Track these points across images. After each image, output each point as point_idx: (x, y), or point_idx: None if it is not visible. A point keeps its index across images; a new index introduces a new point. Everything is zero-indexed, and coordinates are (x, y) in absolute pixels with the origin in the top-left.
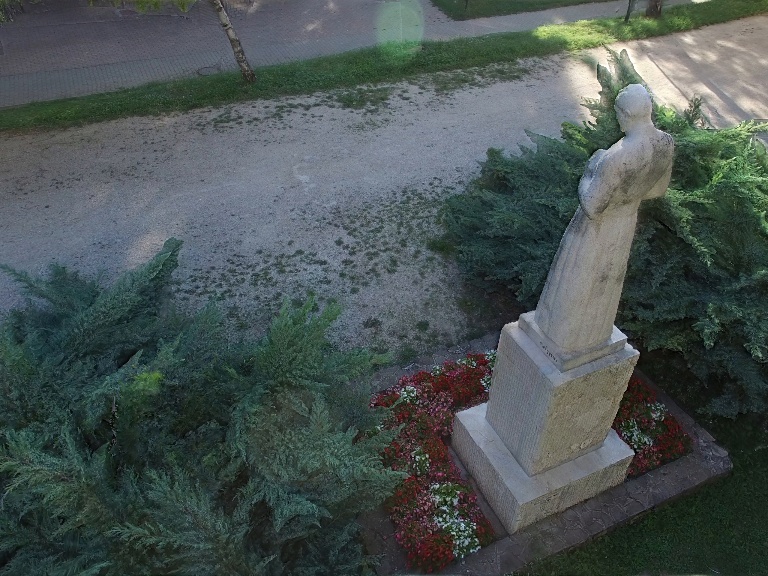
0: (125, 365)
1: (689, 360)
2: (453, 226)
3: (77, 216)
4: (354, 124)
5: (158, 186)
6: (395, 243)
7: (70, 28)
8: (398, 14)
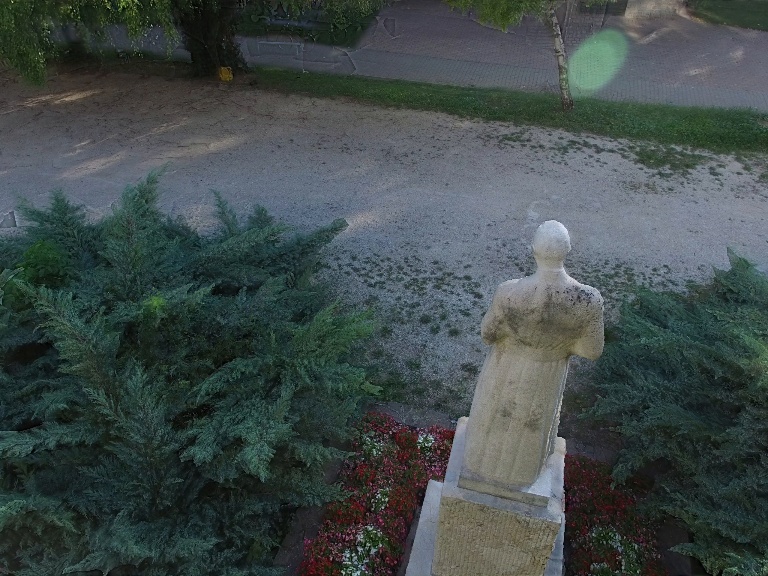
0: (178, 289)
1: None
2: (622, 319)
3: (336, 178)
4: (632, 181)
5: (410, 176)
6: None
7: (473, 24)
8: None
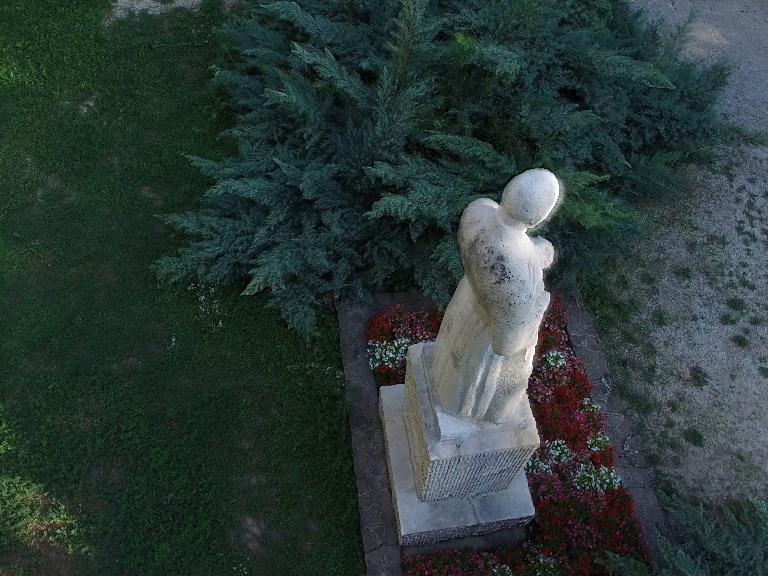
0: None
1: None
2: None
3: None
4: None
5: None
6: None
7: None
8: None
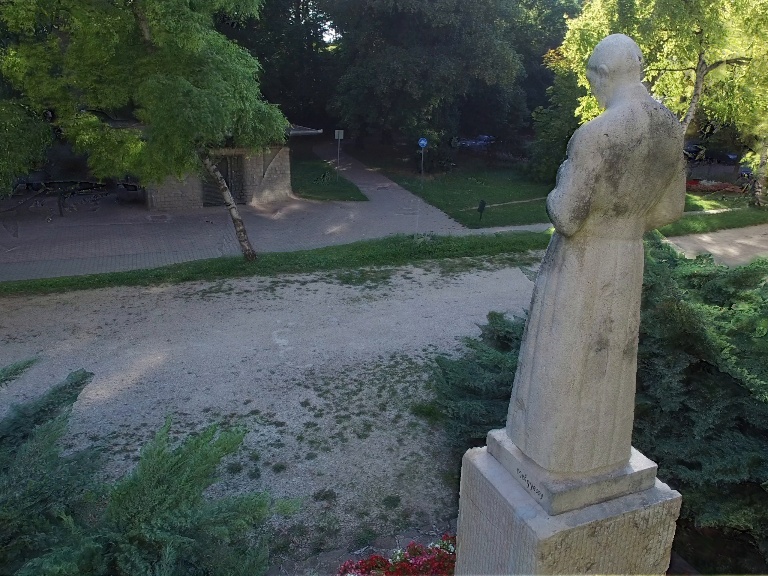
0: None
1: (767, 552)
2: (442, 385)
3: None
4: (349, 297)
5: (118, 344)
6: (372, 406)
7: (100, 228)
8: (415, 223)
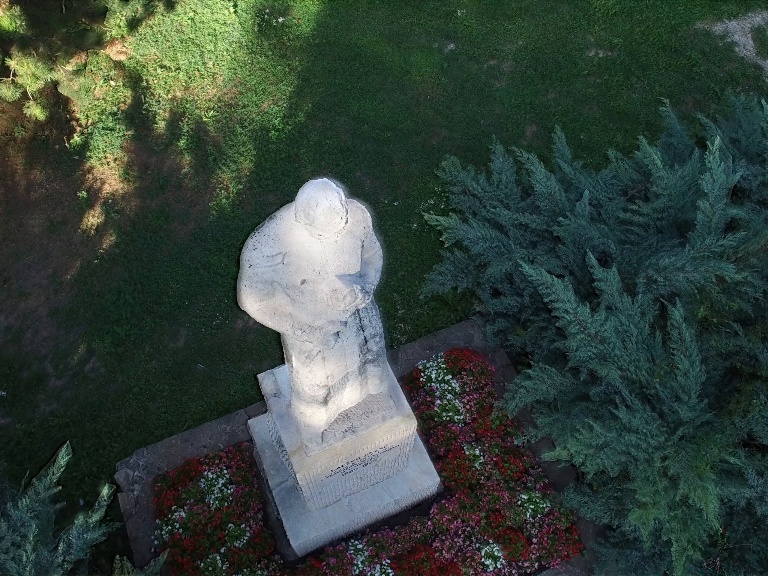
0: None
1: None
2: None
3: None
4: None
5: None
6: None
7: None
8: None
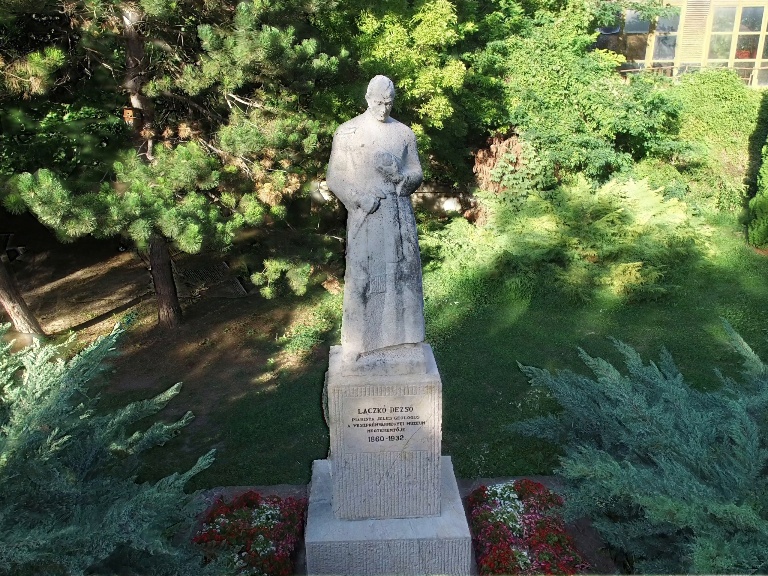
0: None
1: None
2: None
3: None
4: None
5: None
6: None
7: None
8: None
